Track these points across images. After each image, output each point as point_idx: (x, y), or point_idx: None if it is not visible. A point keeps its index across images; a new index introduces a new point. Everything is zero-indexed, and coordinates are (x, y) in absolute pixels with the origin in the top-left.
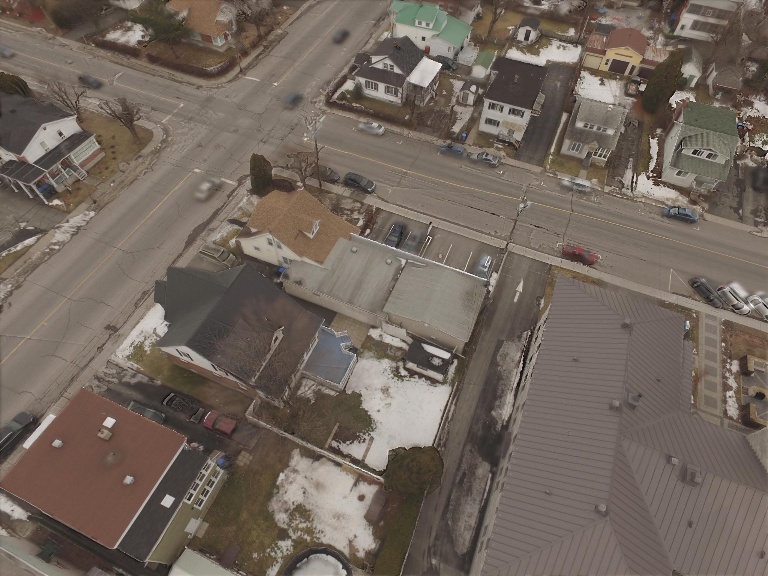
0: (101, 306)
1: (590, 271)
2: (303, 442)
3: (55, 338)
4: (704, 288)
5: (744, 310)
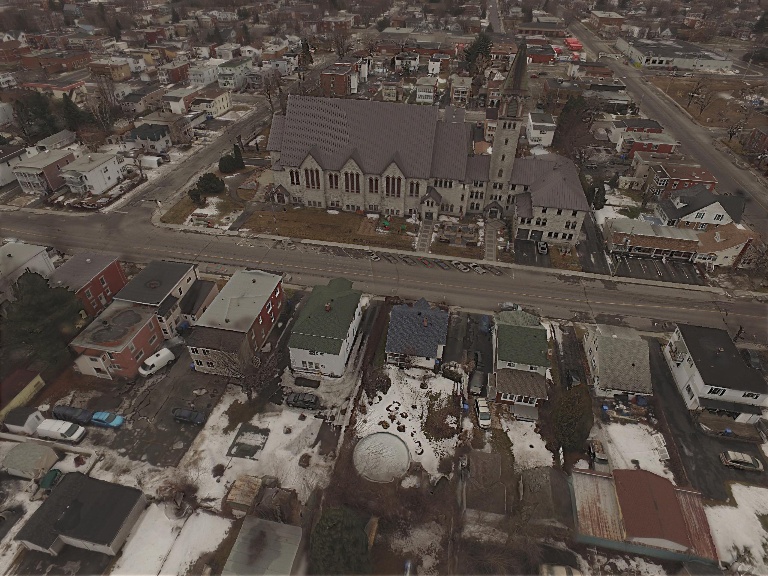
0: (767, 229)
1: (560, 271)
2: (637, 202)
3: (765, 219)
4: (494, 272)
5: (472, 265)
